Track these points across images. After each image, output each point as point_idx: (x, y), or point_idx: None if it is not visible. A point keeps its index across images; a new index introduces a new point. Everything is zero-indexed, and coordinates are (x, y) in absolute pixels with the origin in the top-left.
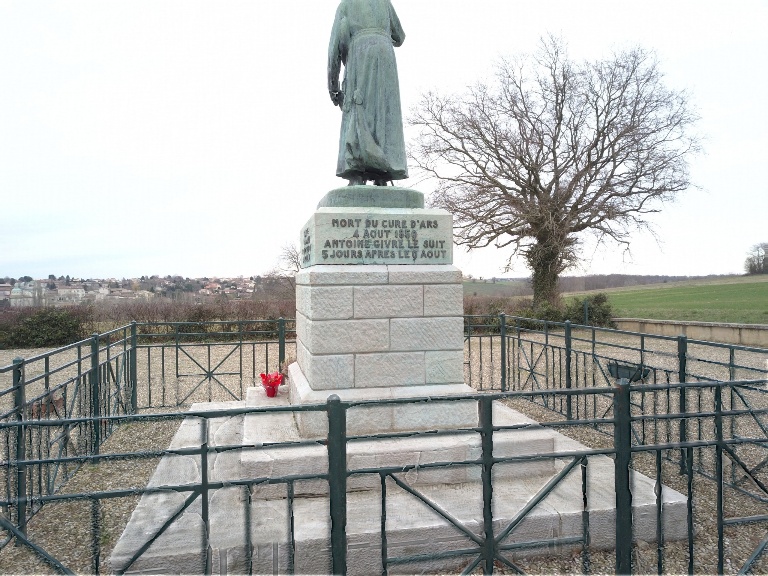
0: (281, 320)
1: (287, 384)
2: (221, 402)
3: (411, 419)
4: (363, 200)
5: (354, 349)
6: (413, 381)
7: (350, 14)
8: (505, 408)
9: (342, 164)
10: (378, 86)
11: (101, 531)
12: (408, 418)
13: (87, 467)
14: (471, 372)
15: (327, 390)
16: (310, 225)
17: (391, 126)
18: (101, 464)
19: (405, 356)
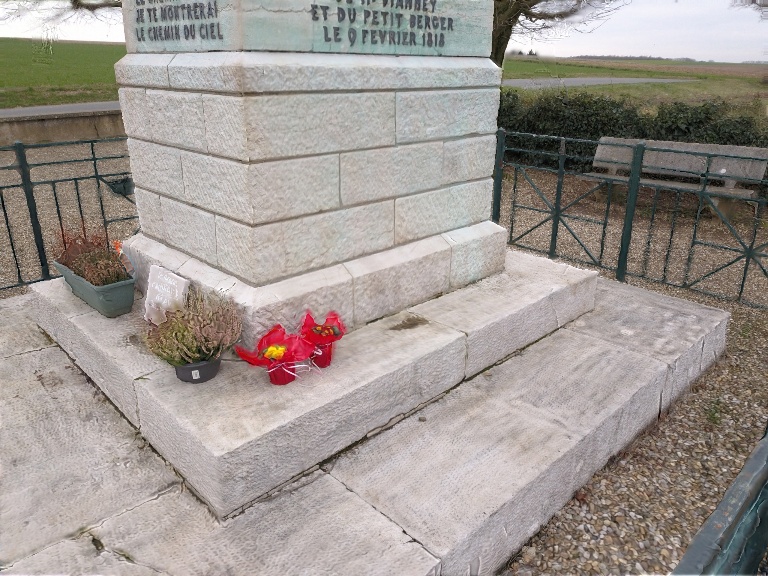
0: None
1: None
2: None
3: None
4: None
5: None
6: None
7: None
8: None
9: None
10: None
11: (714, 446)
12: None
13: None
14: None
15: None
16: None
17: None
18: None
19: None
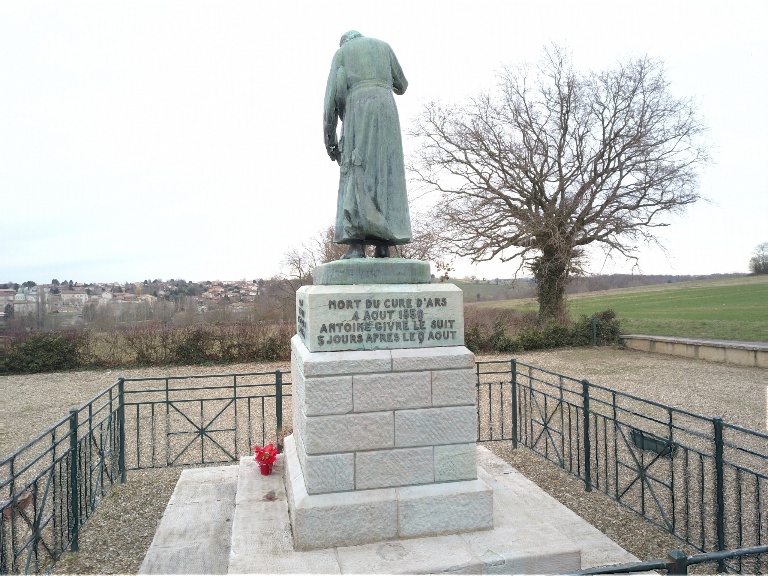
0: (278, 372)
1: (286, 427)
2: (213, 468)
3: (419, 524)
4: (363, 276)
5: (354, 447)
6: (421, 480)
7: (347, 64)
8: (519, 477)
9: (340, 230)
10: (379, 145)
11: None
12: (415, 523)
13: (64, 556)
14: (479, 409)
15: (324, 494)
16: (305, 300)
17: (393, 188)
18: (80, 551)
19: (411, 452)
